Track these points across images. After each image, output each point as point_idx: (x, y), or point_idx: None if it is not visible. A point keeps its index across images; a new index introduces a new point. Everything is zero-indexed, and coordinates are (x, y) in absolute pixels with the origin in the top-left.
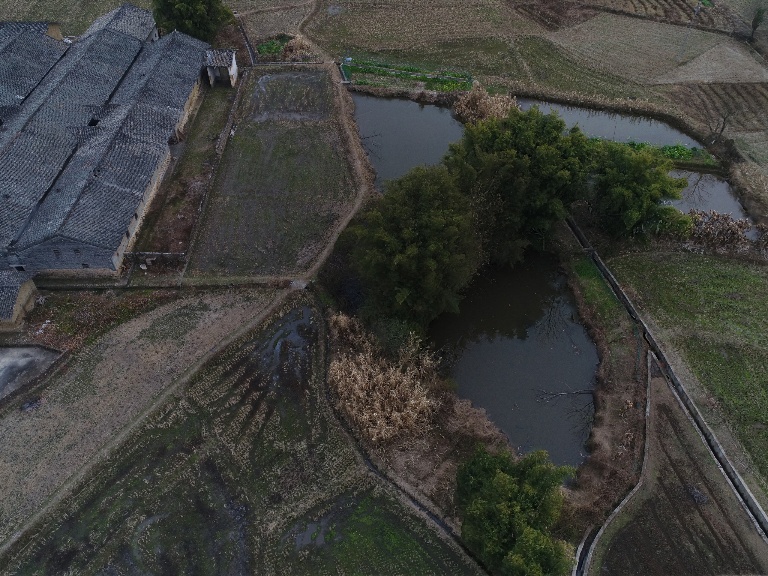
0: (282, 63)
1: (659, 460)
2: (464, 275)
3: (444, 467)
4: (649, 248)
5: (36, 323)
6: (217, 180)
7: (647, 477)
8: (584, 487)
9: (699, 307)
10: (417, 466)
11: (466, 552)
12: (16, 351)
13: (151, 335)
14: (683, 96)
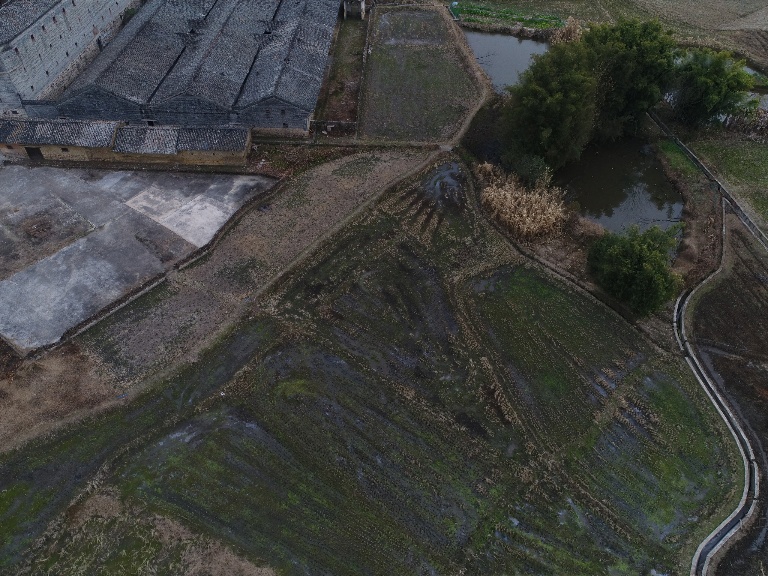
0: (399, 4)
1: (733, 259)
2: (587, 128)
3: (574, 255)
4: (720, 137)
5: (255, 161)
6: (366, 81)
7: (725, 266)
8: (680, 265)
9: (761, 175)
10: (555, 253)
11: (597, 298)
12: (245, 177)
13: (341, 173)
14: (744, 39)
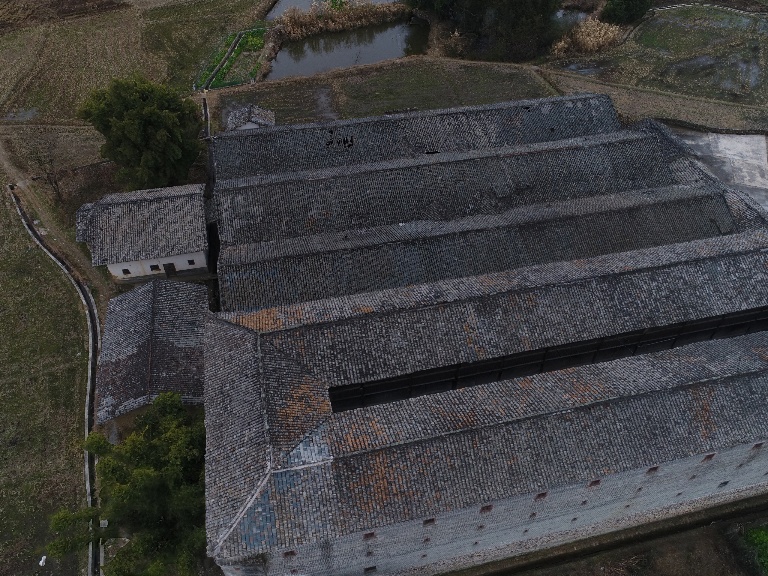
0: None
1: None
2: None
3: None
4: None
5: None
6: None
7: None
8: (597, 3)
9: None
10: None
11: None
12: None
13: None
14: None
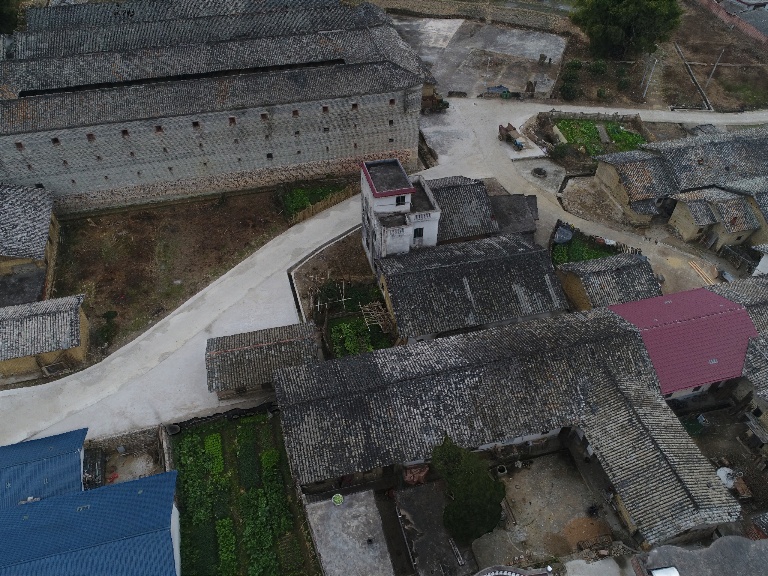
0: None
1: None
2: None
3: None
4: None
5: None
6: None
7: None
8: None
9: None
10: None
11: None
12: None
13: None
14: None
